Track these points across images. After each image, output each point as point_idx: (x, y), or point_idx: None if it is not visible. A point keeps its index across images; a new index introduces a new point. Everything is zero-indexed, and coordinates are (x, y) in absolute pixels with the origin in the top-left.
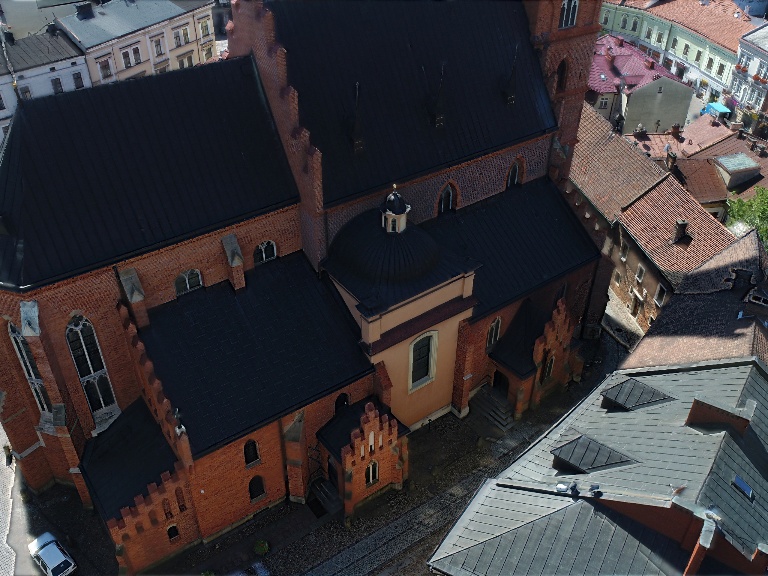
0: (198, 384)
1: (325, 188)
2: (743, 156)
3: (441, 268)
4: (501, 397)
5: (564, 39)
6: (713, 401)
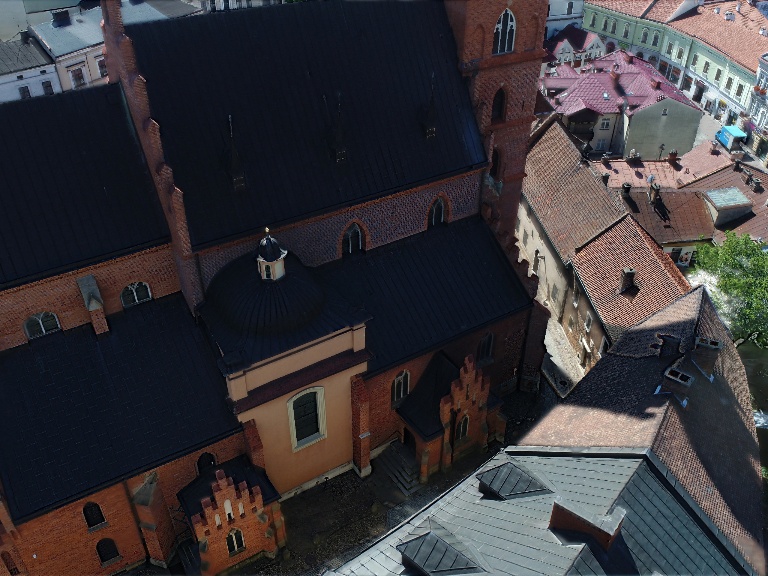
0: (36, 439)
1: (196, 228)
2: (735, 191)
3: (323, 320)
4: (409, 456)
5: (499, 66)
6: (574, 506)
